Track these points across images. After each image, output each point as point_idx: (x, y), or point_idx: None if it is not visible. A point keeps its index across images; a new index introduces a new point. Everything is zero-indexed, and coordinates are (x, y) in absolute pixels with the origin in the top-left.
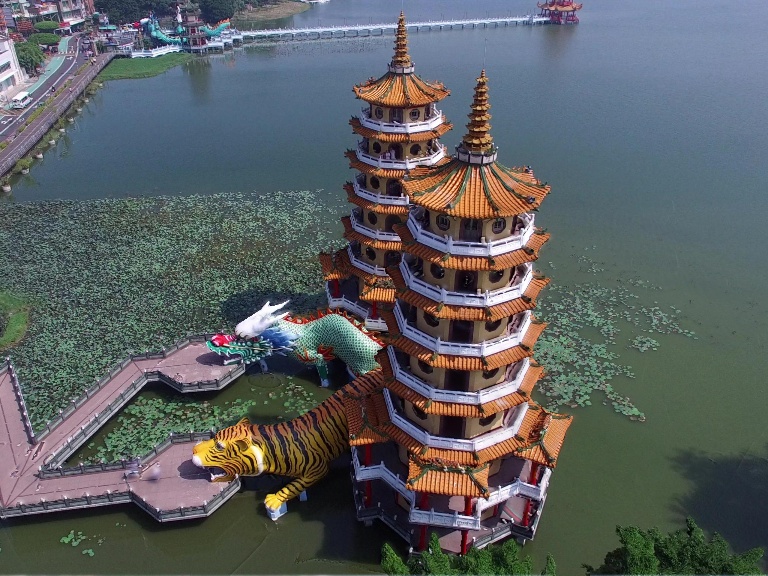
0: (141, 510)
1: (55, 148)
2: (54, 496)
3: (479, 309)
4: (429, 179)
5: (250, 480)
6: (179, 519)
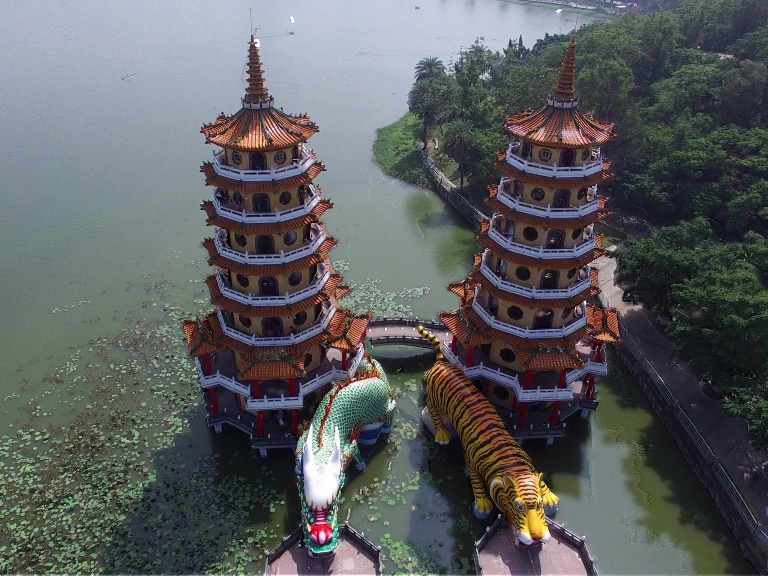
0: None
1: None
2: None
3: None
4: (565, 132)
5: None
6: None
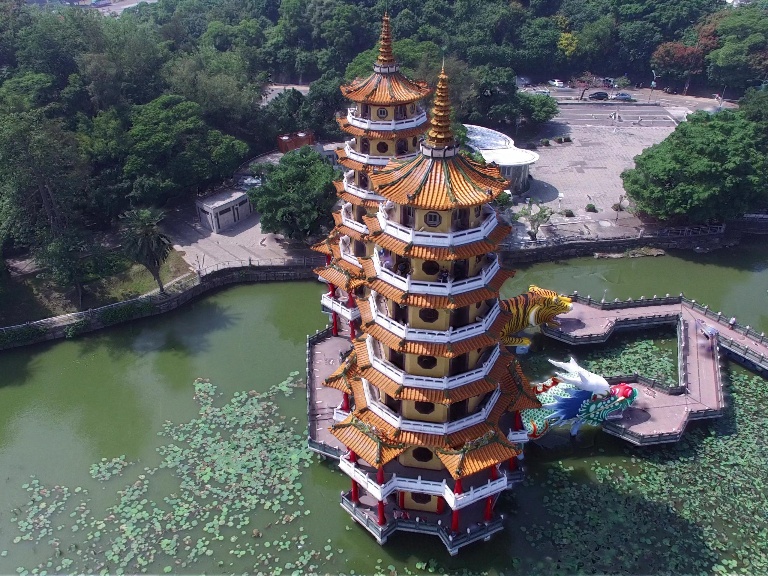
0: None
1: None
2: (657, 310)
3: None
4: None
5: None
6: None
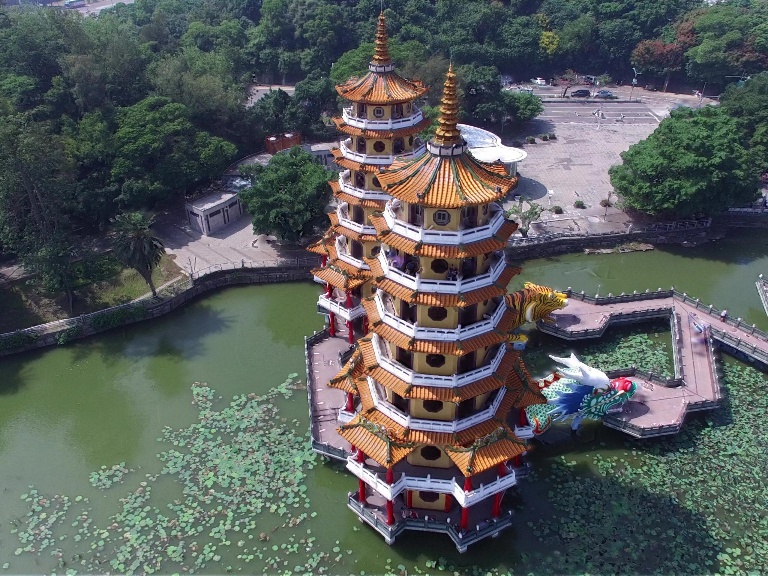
0: None
1: None
2: (650, 304)
3: None
4: None
5: None
6: None
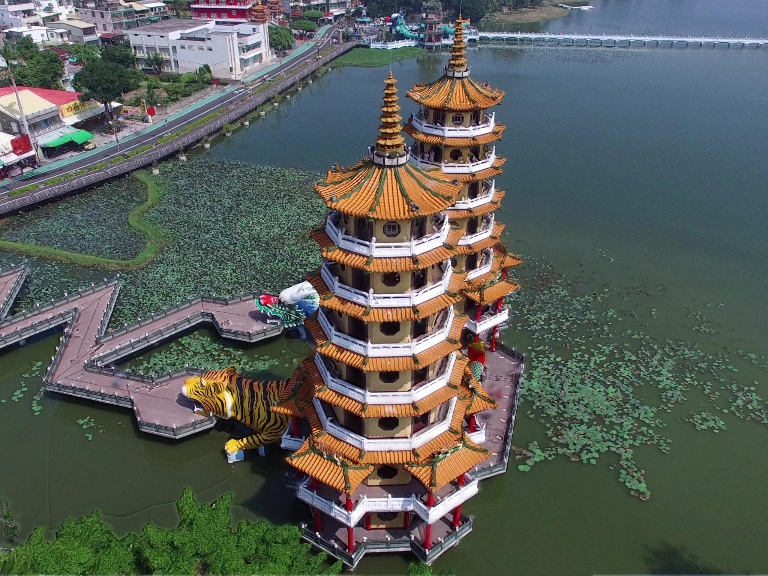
0: (135, 417)
1: (264, 119)
2: (86, 385)
3: (363, 307)
4: (349, 173)
5: (240, 425)
6: (155, 433)
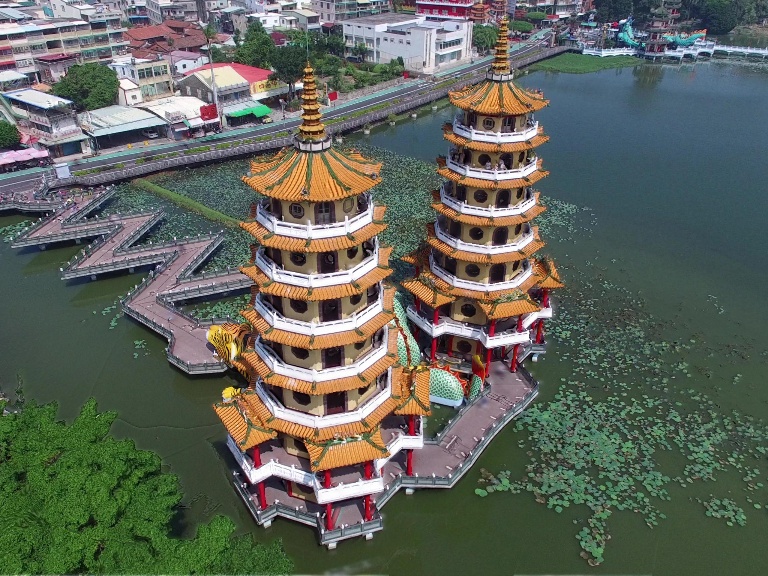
0: None
1: (435, 113)
2: (150, 314)
3: None
4: None
5: None
6: (176, 365)
